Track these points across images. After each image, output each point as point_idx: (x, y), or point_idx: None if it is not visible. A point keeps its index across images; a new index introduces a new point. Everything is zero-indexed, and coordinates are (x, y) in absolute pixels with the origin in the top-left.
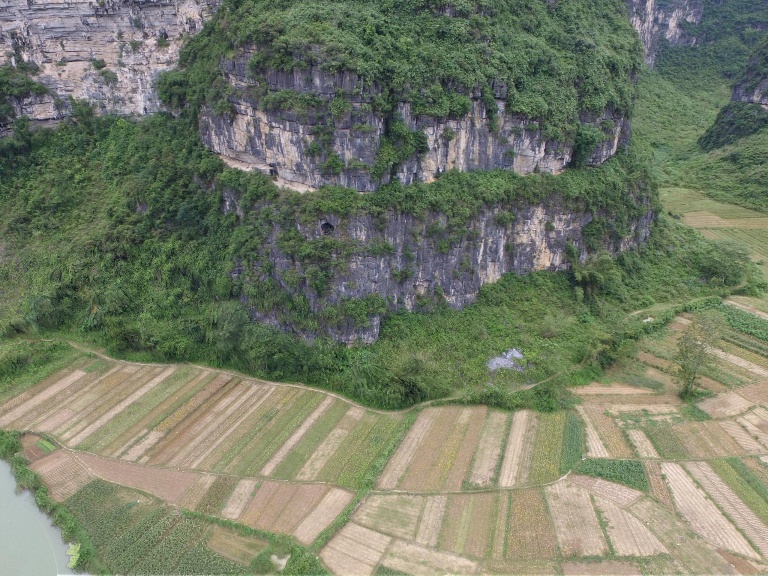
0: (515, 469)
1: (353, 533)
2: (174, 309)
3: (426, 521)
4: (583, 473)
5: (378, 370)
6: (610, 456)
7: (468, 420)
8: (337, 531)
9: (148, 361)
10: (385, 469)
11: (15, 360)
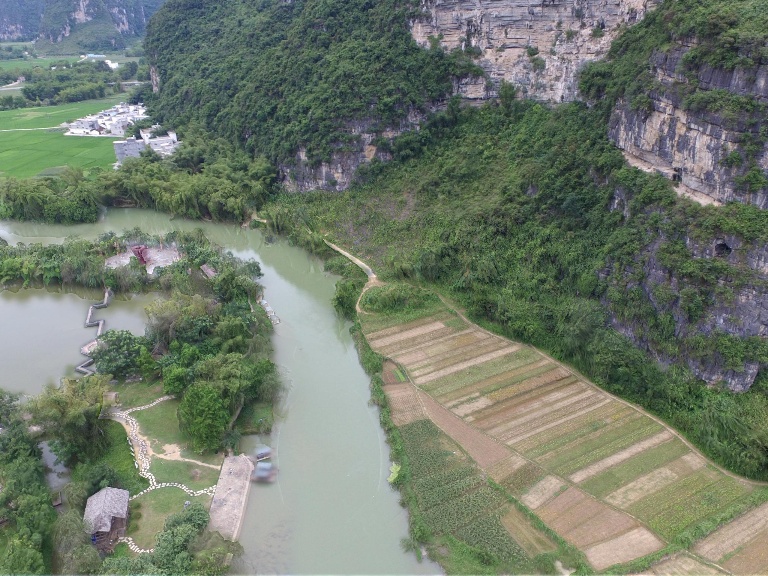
0: None
1: None
2: (534, 292)
3: None
4: None
5: (737, 424)
6: None
7: None
8: (632, 573)
9: (497, 333)
10: (711, 536)
11: (396, 298)
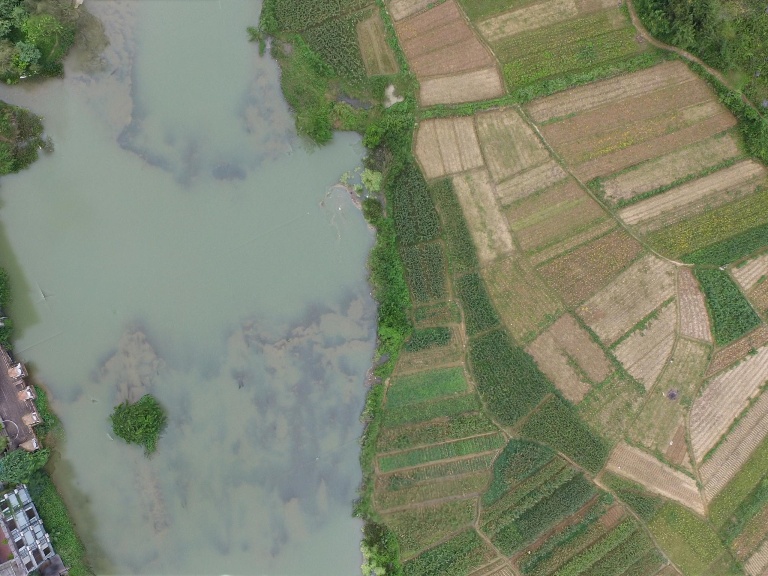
0: (653, 213)
1: (462, 130)
2: None
3: (524, 179)
4: (698, 278)
5: None
6: (748, 290)
7: (695, 120)
8: (453, 115)
9: None
10: (555, 95)
11: None
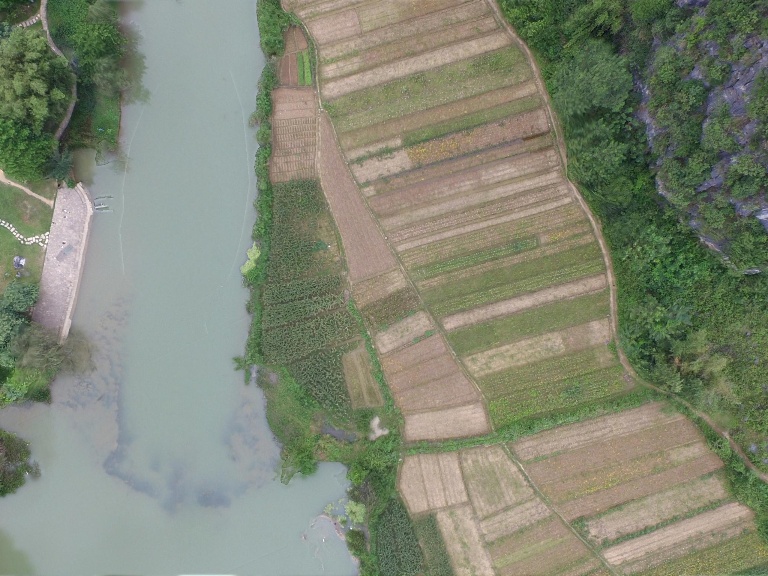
0: (638, 554)
1: (447, 466)
2: None
3: (508, 516)
4: None
5: (667, 339)
6: None
7: (682, 460)
8: (438, 451)
9: None
10: (540, 433)
11: None
